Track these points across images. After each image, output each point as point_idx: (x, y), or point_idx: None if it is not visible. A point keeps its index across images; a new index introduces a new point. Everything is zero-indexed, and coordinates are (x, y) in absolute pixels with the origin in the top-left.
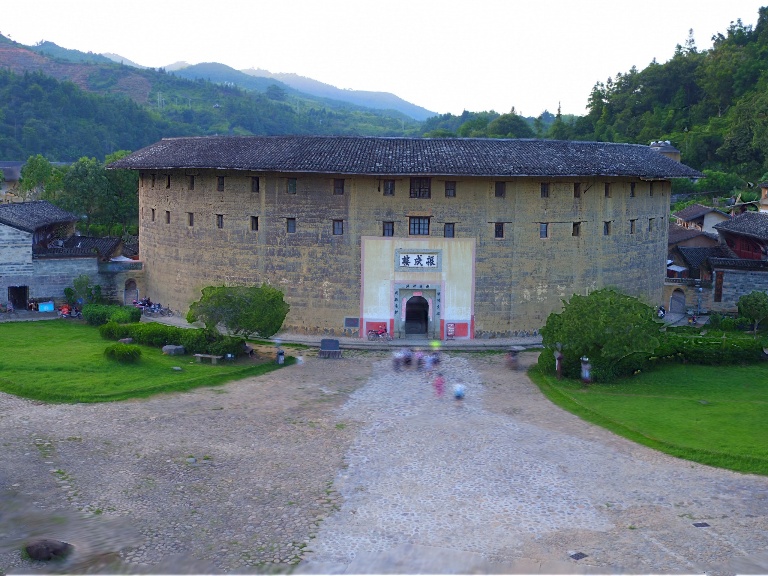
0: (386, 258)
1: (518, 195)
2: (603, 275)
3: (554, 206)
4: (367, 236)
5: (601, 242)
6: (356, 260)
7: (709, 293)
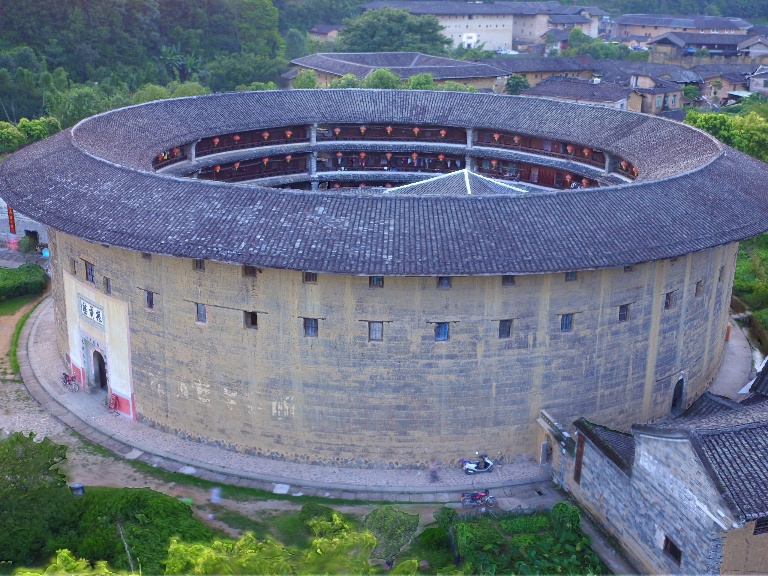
0: (74, 300)
1: (165, 260)
2: (305, 391)
3: (211, 284)
4: (65, 270)
5: (298, 345)
6: (63, 293)
7: (571, 462)
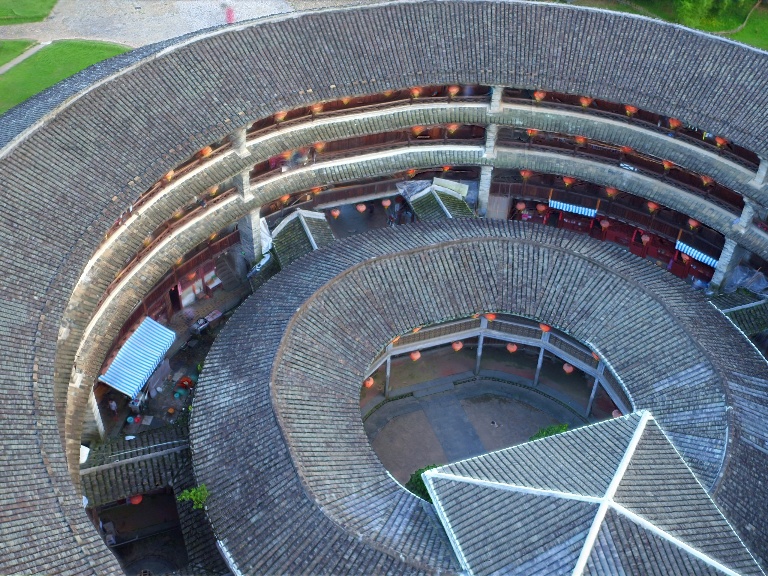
0: None
1: None
2: None
3: None
4: None
5: None
6: None
7: None
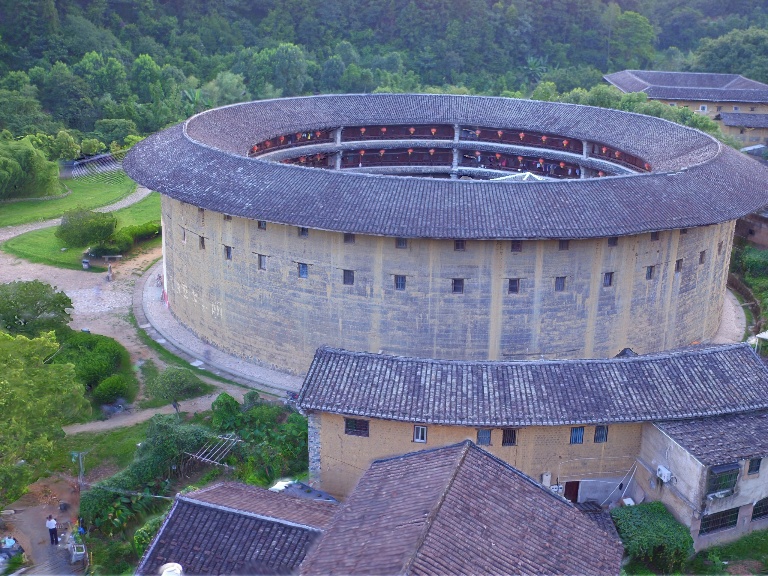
0: None
1: None
2: None
3: None
4: None
5: None
6: None
7: None
